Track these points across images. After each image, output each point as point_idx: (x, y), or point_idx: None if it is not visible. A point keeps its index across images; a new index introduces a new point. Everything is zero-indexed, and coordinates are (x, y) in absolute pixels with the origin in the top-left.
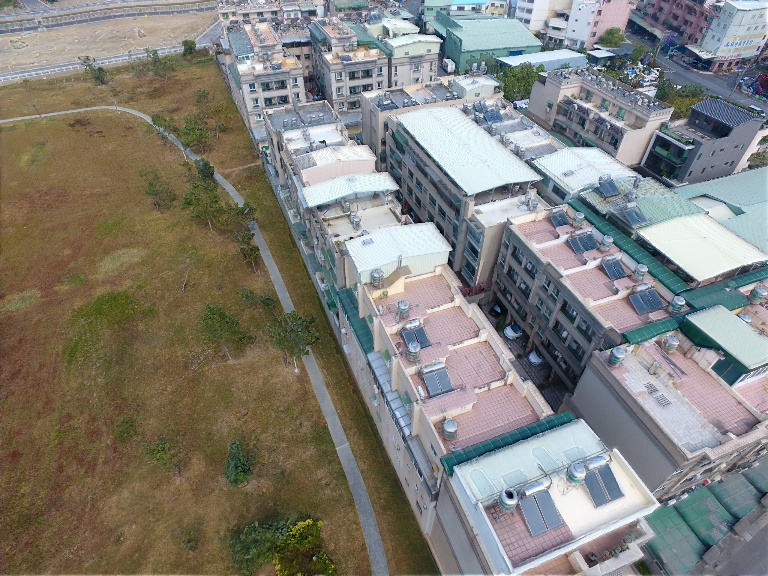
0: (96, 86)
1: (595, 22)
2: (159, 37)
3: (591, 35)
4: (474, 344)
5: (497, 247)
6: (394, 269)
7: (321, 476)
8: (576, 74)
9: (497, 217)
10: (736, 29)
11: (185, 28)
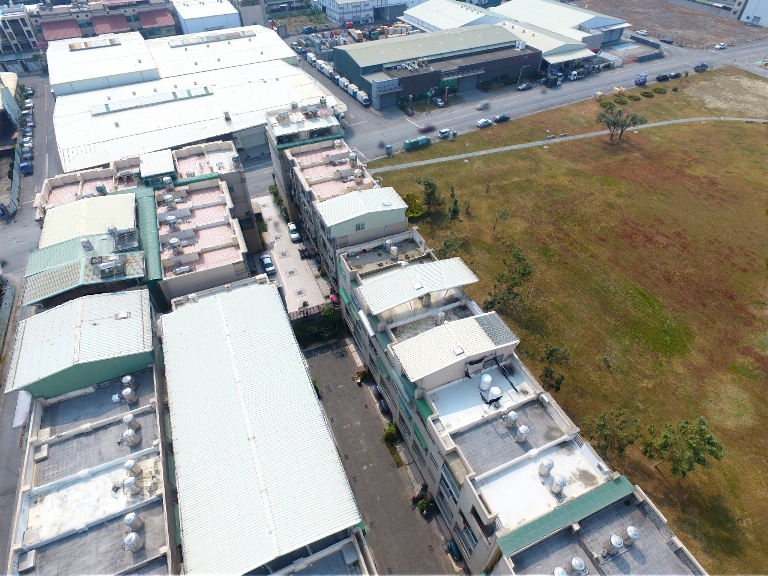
0: None
1: None
2: None
3: None
4: None
5: None
6: None
7: None
8: None
9: None
10: None
11: None
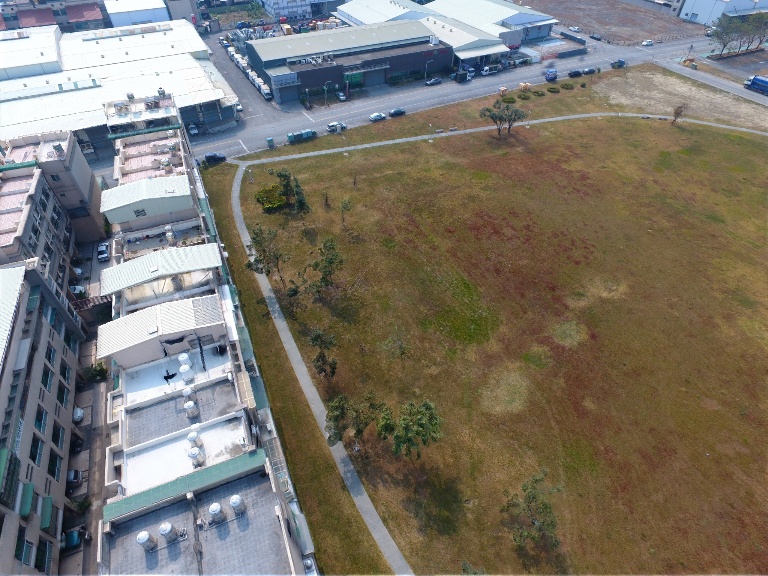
0: None
1: None
2: None
3: None
4: None
5: None
6: None
7: None
8: None
9: None
10: None
11: None
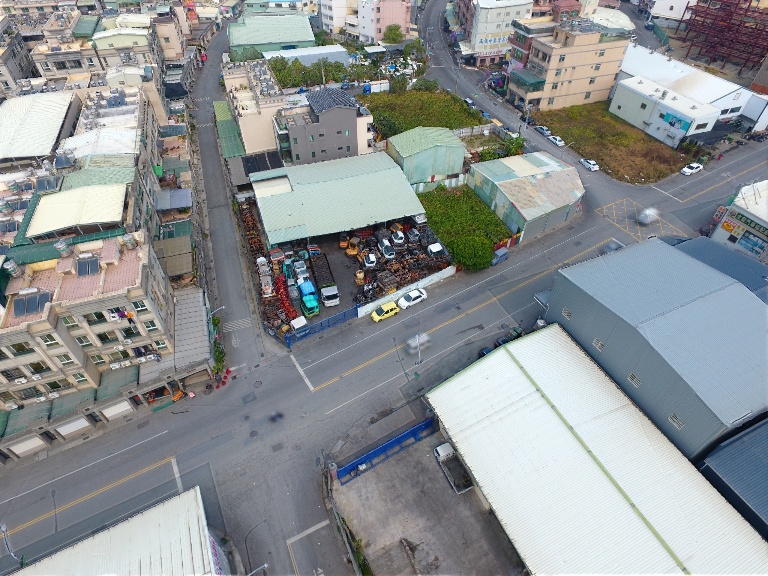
0: None
1: (377, 19)
2: None
3: (377, 31)
4: None
5: None
6: None
7: None
8: None
9: None
10: (484, 26)
11: None
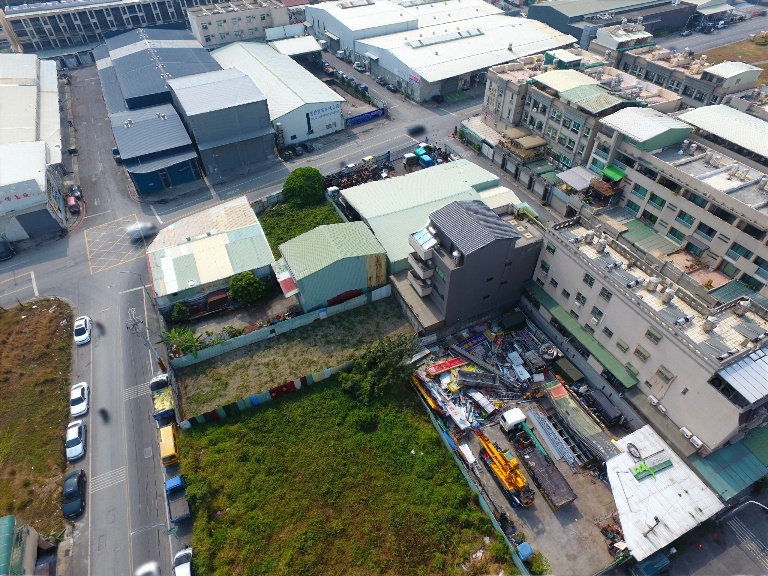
0: None
1: None
2: None
3: None
4: None
5: None
6: None
7: None
8: None
9: None
10: None
11: None
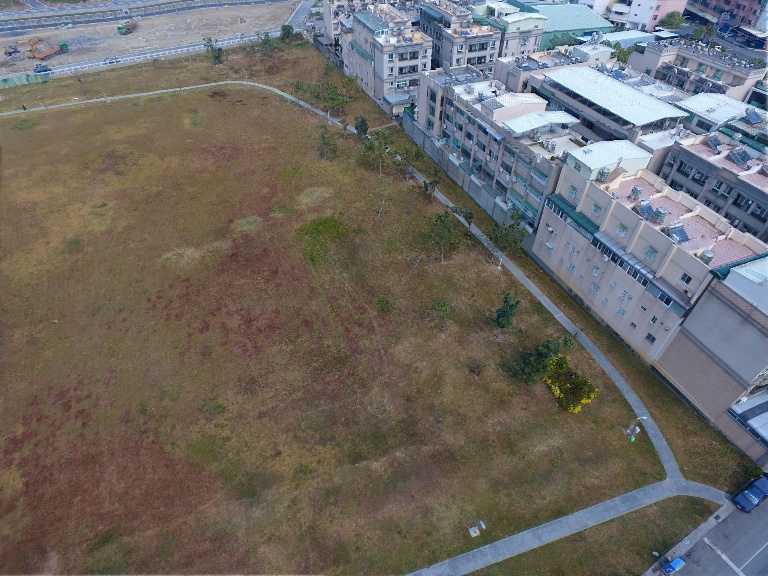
0: (214, 65)
1: (657, 6)
2: (248, 24)
3: (652, 18)
4: (690, 217)
5: (657, 169)
6: (613, 170)
7: (551, 332)
8: (670, 44)
9: (658, 144)
10: None
11: (268, 16)
